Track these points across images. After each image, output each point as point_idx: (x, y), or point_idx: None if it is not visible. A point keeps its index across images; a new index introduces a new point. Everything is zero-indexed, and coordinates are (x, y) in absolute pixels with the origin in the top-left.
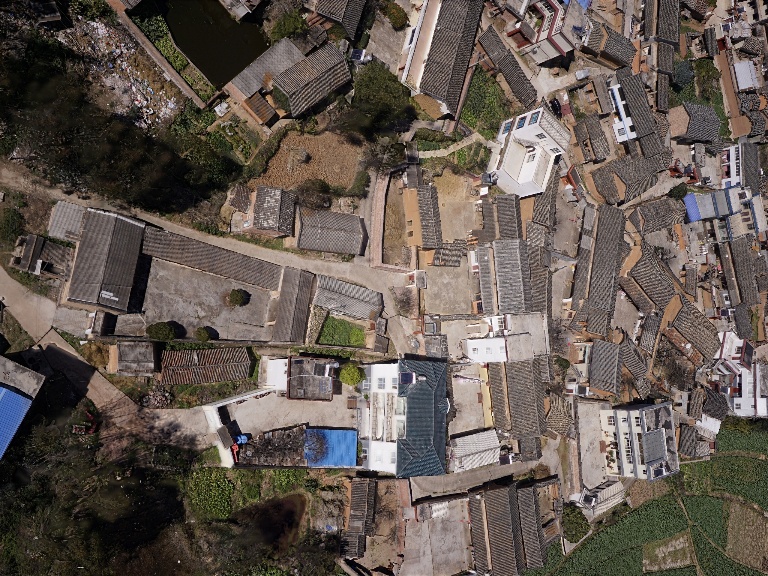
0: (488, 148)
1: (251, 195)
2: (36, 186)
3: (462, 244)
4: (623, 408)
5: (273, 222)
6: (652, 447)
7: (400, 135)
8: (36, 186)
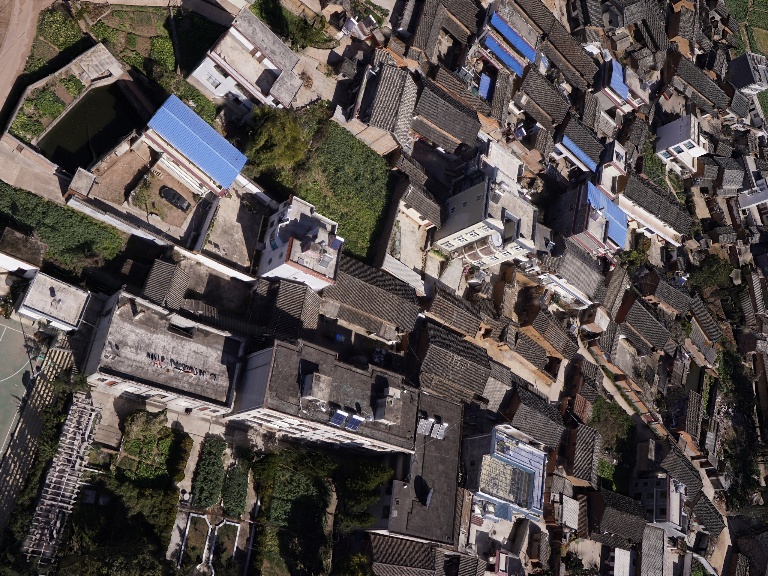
0: (670, 171)
1: (748, 353)
2: (760, 457)
3: (718, 207)
4: (735, 84)
5: (765, 344)
6: (762, 78)
7: (685, 245)
8: (760, 457)
